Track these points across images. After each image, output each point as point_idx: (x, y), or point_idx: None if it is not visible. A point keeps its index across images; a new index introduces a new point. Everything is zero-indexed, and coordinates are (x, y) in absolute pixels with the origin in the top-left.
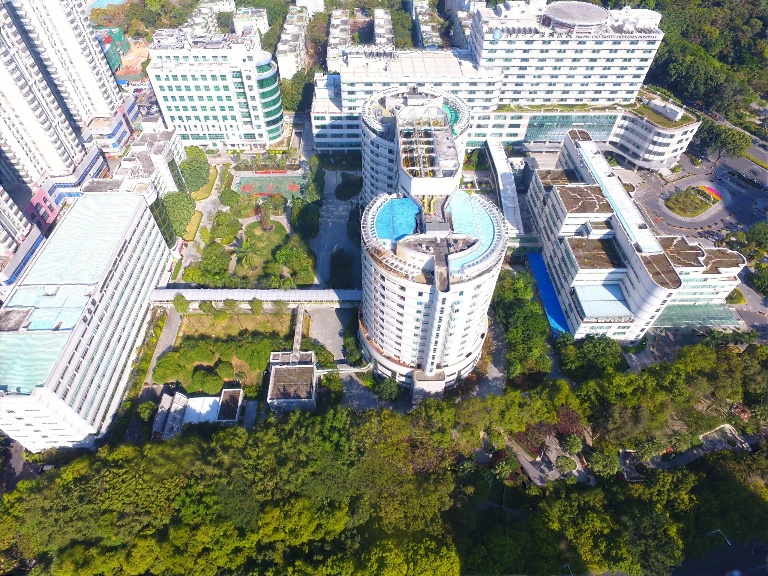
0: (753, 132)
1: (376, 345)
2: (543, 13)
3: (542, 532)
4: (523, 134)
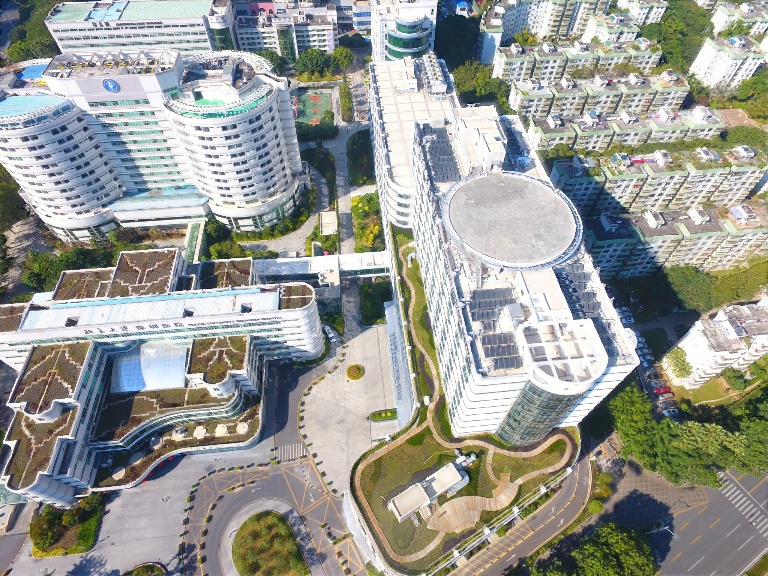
0: None
1: None
2: (485, 169)
3: None
4: None
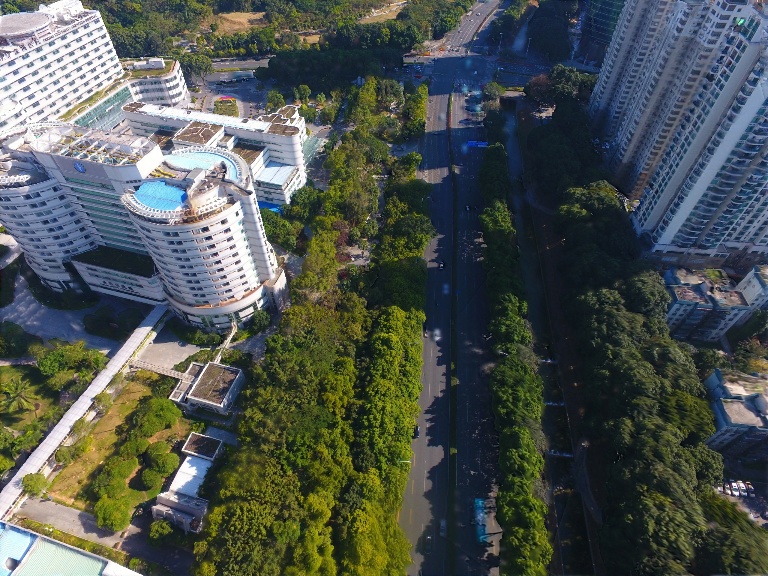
0: None
1: (227, 302)
2: None
3: (397, 265)
4: None
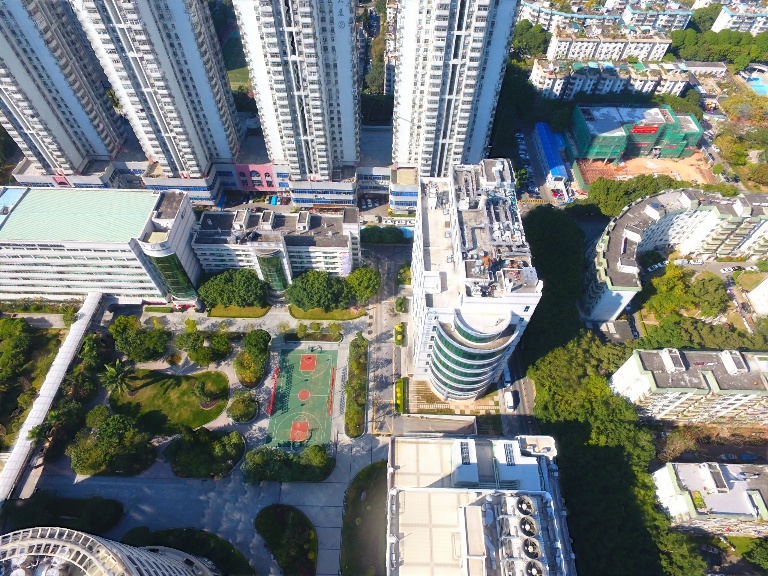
0: None
1: None
2: None
3: None
4: None
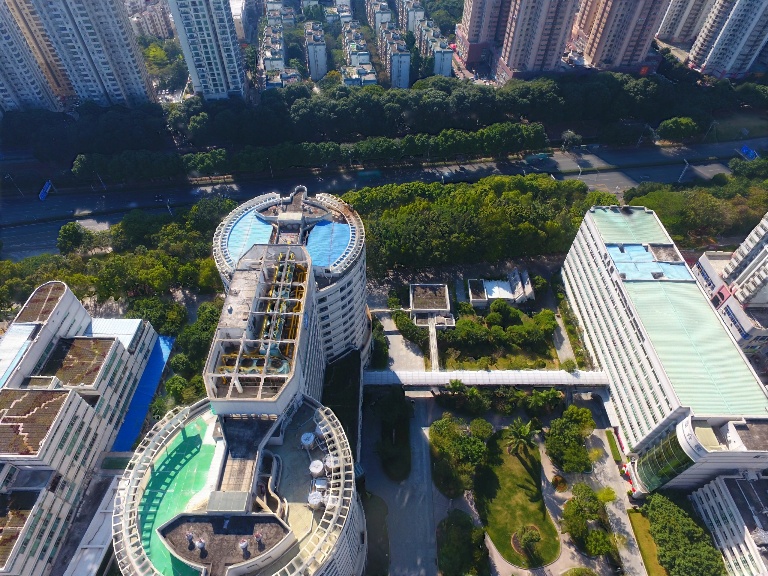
0: None
1: None
2: None
3: None
4: None
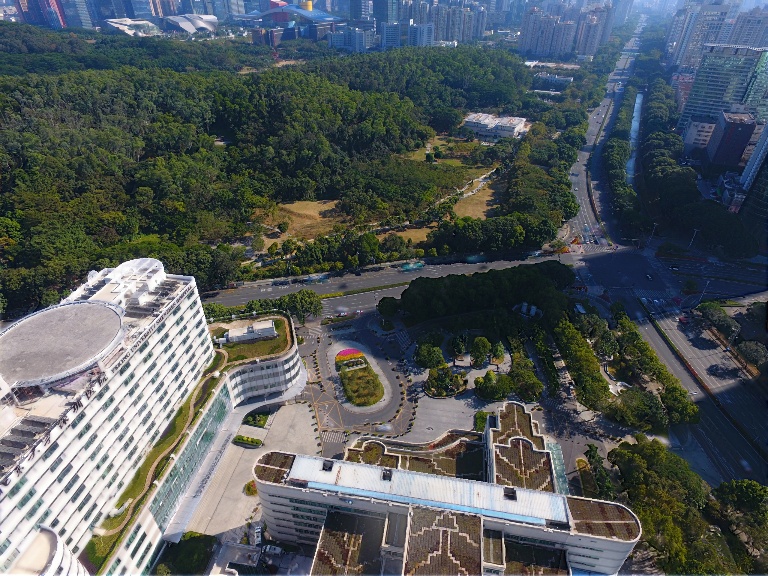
0: (272, 276)
1: None
2: (8, 389)
3: None
4: (156, 532)
